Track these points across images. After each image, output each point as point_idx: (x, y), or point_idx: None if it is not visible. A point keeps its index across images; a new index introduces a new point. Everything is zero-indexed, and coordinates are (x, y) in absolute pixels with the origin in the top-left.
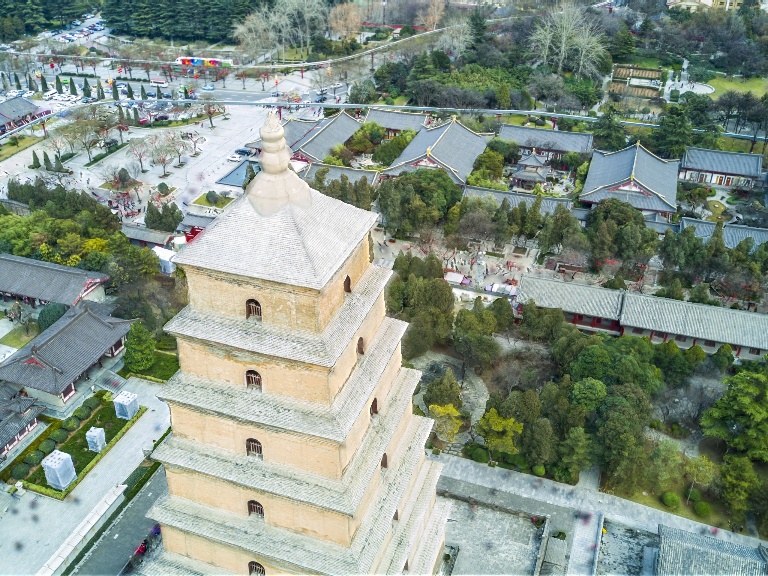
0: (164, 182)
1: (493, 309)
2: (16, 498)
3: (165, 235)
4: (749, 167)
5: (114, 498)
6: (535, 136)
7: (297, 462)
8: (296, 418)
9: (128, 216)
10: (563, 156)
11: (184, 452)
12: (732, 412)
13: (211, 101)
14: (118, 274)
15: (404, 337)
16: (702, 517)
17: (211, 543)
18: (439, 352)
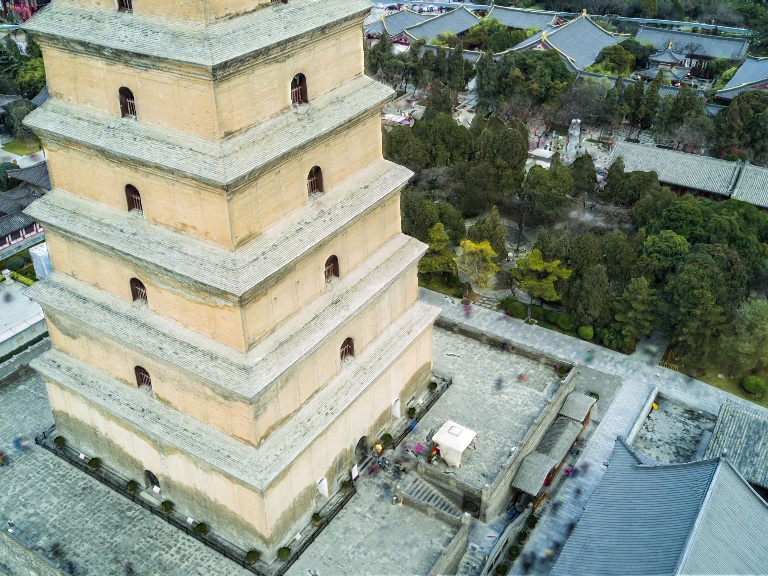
0: None
1: (572, 168)
2: (1, 285)
3: None
4: None
5: None
6: (678, 40)
7: (171, 118)
8: (163, 41)
9: None
10: (708, 64)
11: (56, 115)
12: None
13: None
14: None
15: (458, 186)
16: None
17: (92, 252)
18: (502, 216)
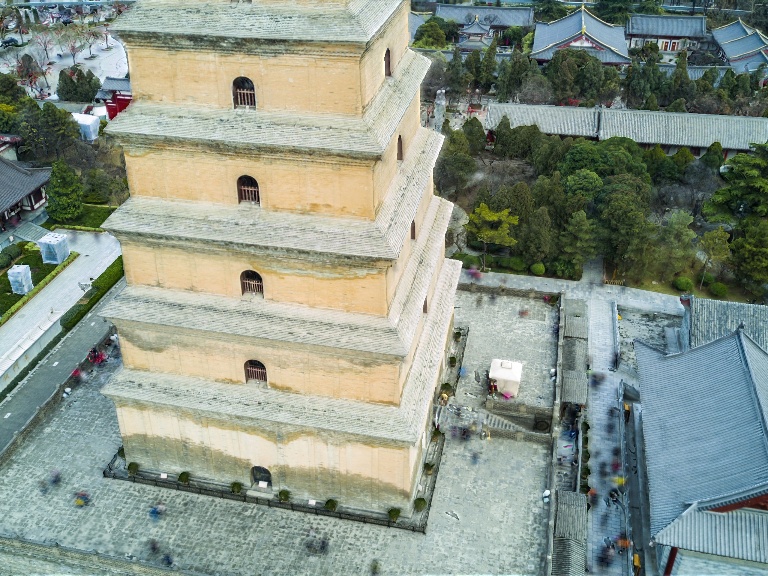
0: (75, 66)
1: None
2: None
3: (82, 104)
4: (694, 30)
5: (49, 324)
6: (474, 14)
7: (302, 101)
8: (301, 24)
9: None
10: (504, 32)
11: (149, 117)
12: (738, 191)
13: (120, 1)
14: (31, 136)
15: None
16: (719, 298)
17: (190, 255)
18: None
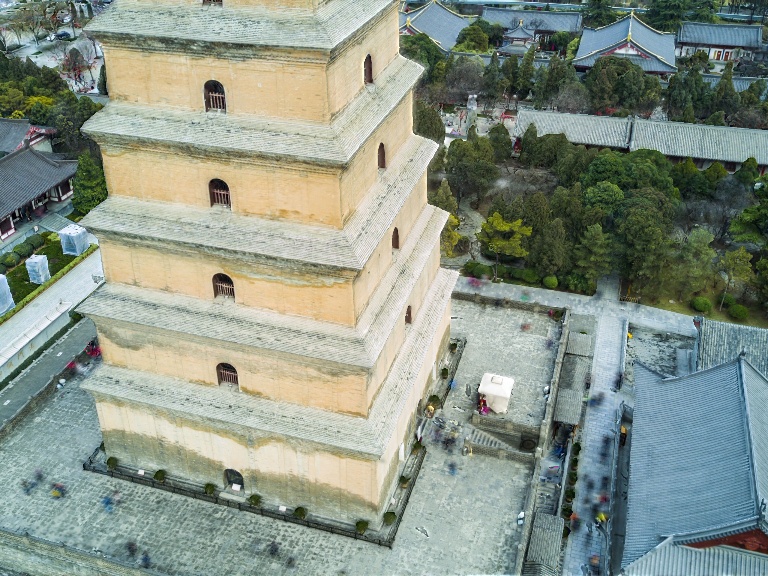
0: None
1: (489, 139)
2: None
3: None
4: (748, 39)
5: (57, 314)
6: (520, 18)
7: (271, 106)
8: (268, 29)
9: (80, 92)
10: (551, 37)
11: (124, 117)
12: (767, 210)
13: None
14: (66, 128)
15: None
16: (739, 321)
17: (164, 255)
18: (429, 191)
